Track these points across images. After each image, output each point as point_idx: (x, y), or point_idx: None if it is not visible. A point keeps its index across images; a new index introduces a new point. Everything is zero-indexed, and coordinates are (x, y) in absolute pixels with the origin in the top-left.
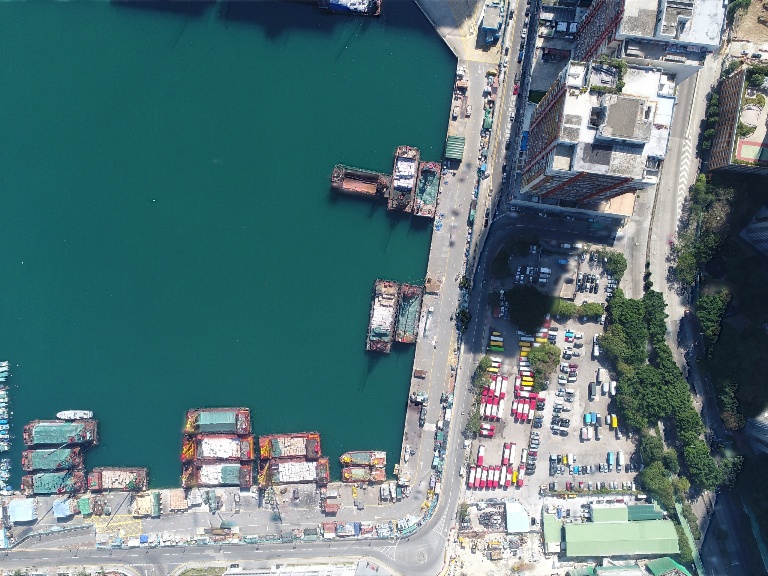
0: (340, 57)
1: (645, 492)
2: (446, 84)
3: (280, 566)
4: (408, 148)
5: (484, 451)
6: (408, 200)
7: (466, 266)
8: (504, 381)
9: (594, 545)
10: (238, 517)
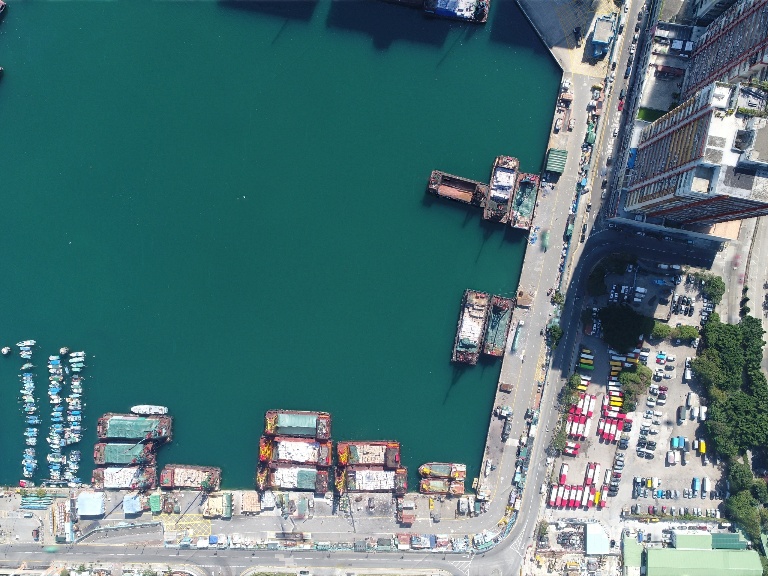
0: (442, 62)
1: (730, 520)
2: (549, 96)
3: (351, 575)
4: (509, 158)
5: (567, 470)
6: (504, 211)
7: (559, 281)
8: (592, 400)
9: (676, 572)
10: (311, 523)
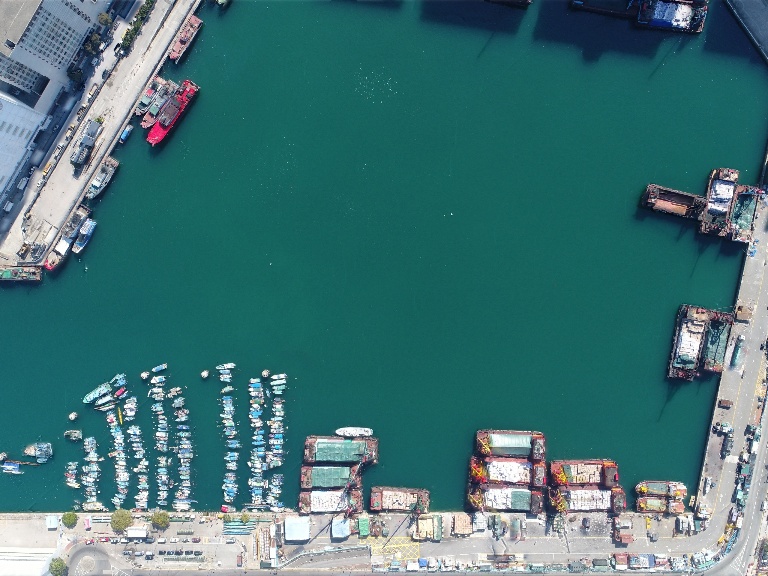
0: (654, 74)
1: None
2: (765, 106)
3: None
4: (730, 171)
5: None
6: None
7: None
8: None
9: None
10: (523, 544)
